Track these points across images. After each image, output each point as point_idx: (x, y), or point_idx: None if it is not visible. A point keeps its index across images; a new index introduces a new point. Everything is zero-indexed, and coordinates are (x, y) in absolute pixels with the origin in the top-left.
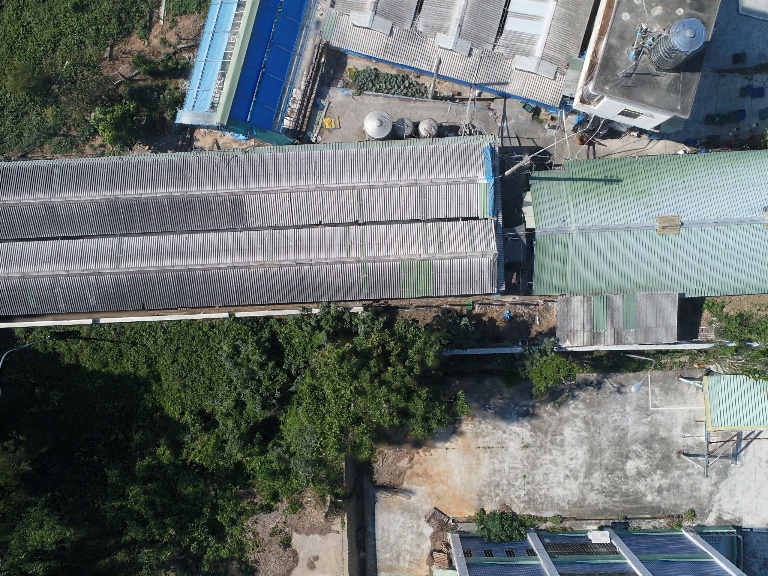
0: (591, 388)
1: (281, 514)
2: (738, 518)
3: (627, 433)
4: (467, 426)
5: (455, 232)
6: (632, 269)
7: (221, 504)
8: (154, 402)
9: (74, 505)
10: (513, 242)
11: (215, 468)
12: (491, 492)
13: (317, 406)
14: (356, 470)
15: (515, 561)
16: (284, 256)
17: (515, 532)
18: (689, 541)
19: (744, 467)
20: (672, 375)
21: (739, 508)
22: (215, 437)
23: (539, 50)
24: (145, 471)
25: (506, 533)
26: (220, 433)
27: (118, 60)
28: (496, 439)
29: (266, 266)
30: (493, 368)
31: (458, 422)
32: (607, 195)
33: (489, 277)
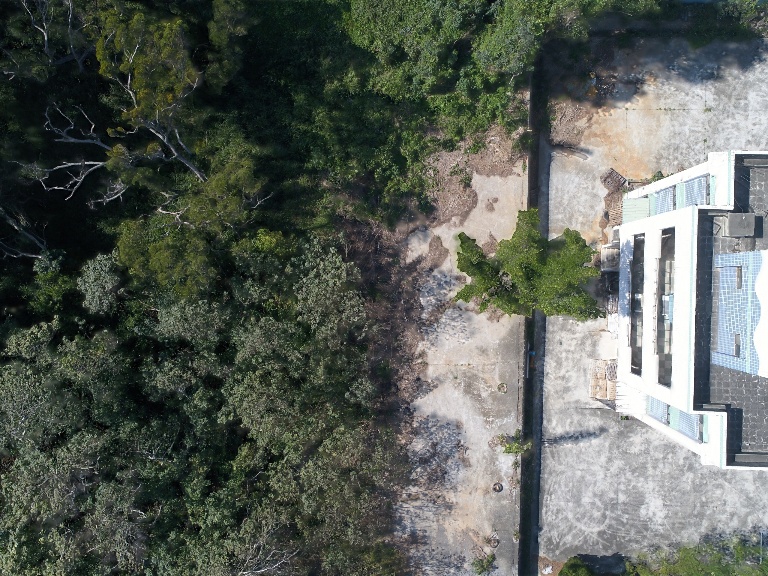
0: None
1: (463, 154)
2: None
3: None
4: (649, 87)
5: None
6: None
7: (405, 137)
8: (343, 31)
9: (262, 122)
10: None
11: (401, 100)
12: (670, 155)
13: None
14: (532, 129)
15: None
16: None
17: None
18: None
19: None
20: None
21: None
22: (402, 70)
23: None
24: (333, 95)
25: None
26: (407, 67)
27: None
28: (678, 101)
29: None
30: (680, 27)
31: (640, 82)
32: None
33: None
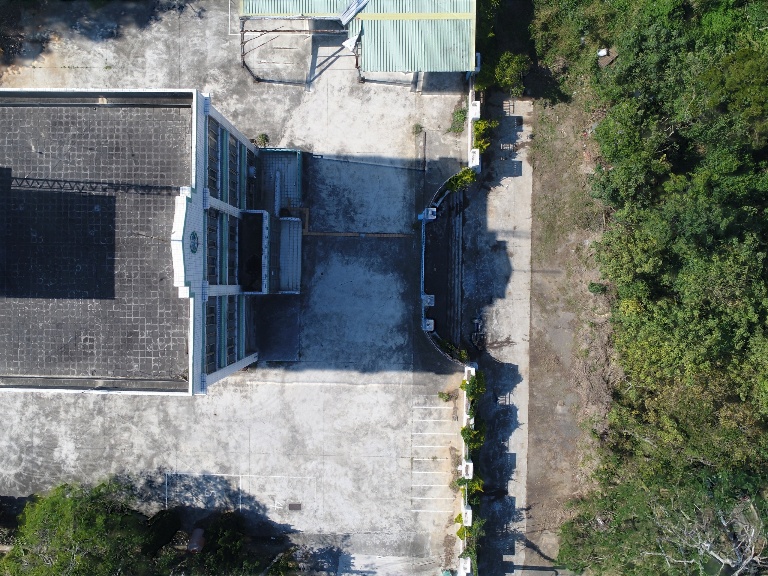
0: (173, 12)
1: None
2: (309, 145)
3: (206, 57)
4: (54, 46)
5: None
6: None
7: None
8: None
9: None
10: None
11: None
12: None
13: None
14: None
15: None
16: None
17: None
18: None
19: (317, 95)
20: None
21: (310, 135)
22: None
23: None
24: None
25: None
26: None
27: None
28: (81, 59)
29: None
30: None
31: (46, 42)
32: None
33: None
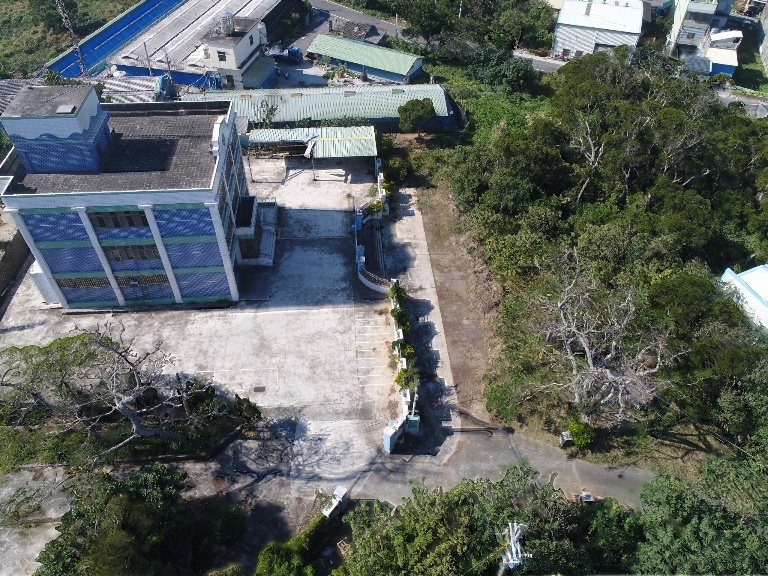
0: None
1: None
2: (283, 204)
3: None
4: None
5: None
6: None
7: None
8: None
9: None
10: None
11: None
12: None
13: None
14: None
15: None
16: None
17: None
18: None
19: (288, 186)
20: (253, 157)
21: (284, 200)
22: None
23: (198, 59)
24: None
25: None
26: None
27: (14, 76)
28: None
29: None
30: None
31: None
32: None
33: None
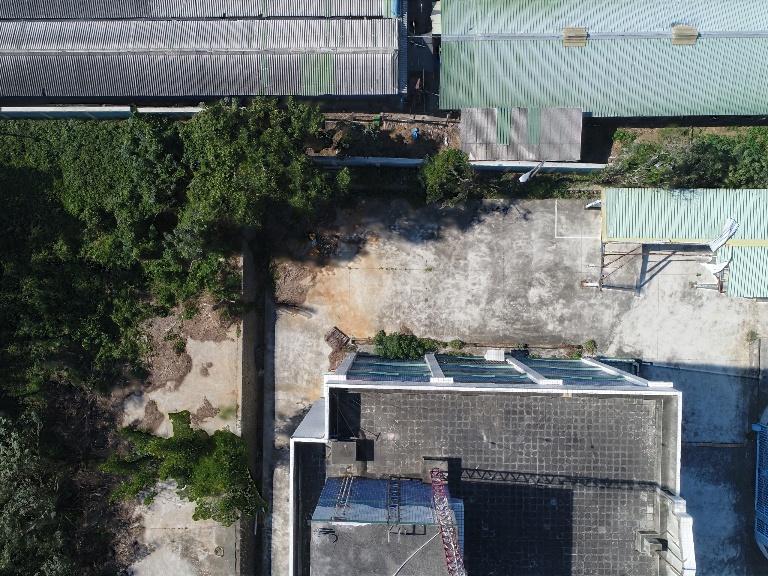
0: (497, 213)
1: (177, 319)
2: (639, 351)
3: (531, 260)
4: (371, 246)
5: (358, 29)
6: (538, 83)
7: (116, 304)
8: (54, 198)
9: None
10: (419, 49)
11: (112, 267)
12: (392, 314)
13: (204, 183)
14: (258, 287)
15: (402, 363)
16: (185, 44)
17: (412, 351)
18: (584, 364)
19: (647, 300)
20: (579, 204)
21: (640, 341)
22: (114, 237)
23: None
24: (40, 264)
25: (403, 351)
26: (119, 233)
27: None
28: (400, 261)
29: (166, 53)
30: (400, 188)
31: (362, 242)
32: (516, 6)
33: (390, 76)
